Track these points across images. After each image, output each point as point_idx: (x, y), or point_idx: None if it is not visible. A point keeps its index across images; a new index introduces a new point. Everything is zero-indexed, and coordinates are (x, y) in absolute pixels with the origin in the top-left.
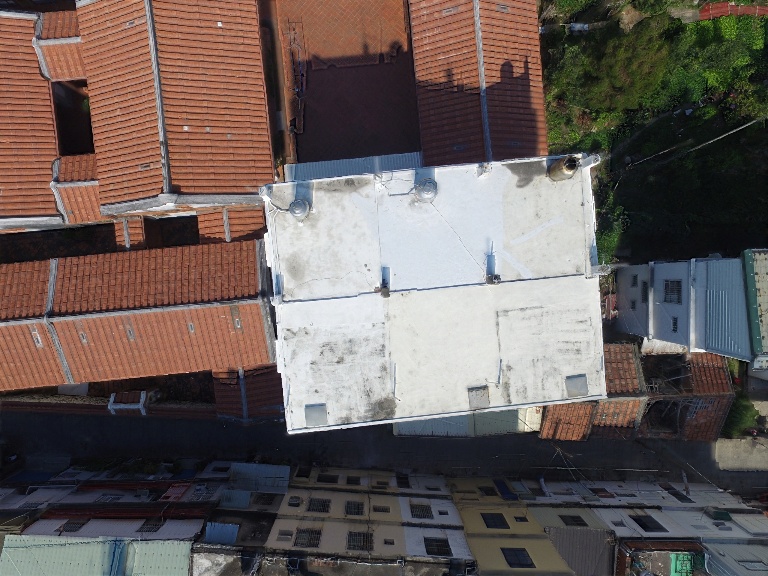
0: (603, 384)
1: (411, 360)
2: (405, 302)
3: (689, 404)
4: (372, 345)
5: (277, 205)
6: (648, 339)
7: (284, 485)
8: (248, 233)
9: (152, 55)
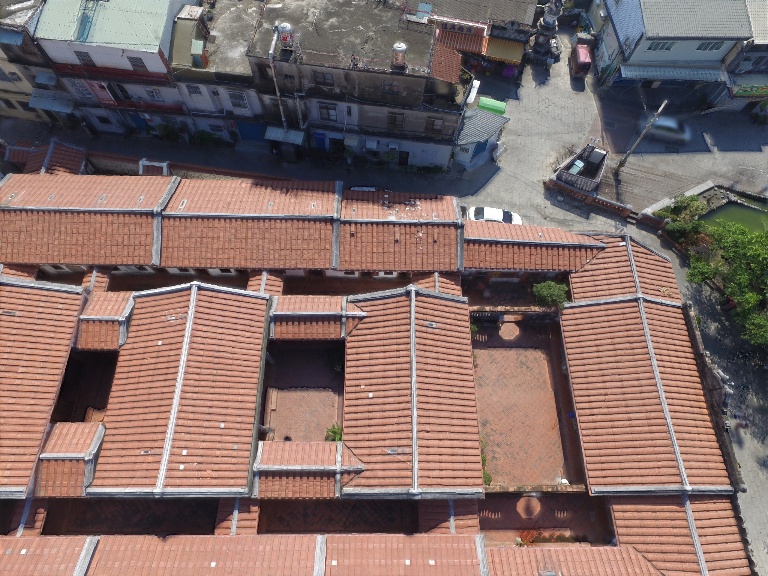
0: None
1: None
2: None
3: None
4: None
5: None
6: None
7: (35, 94)
8: None
9: None
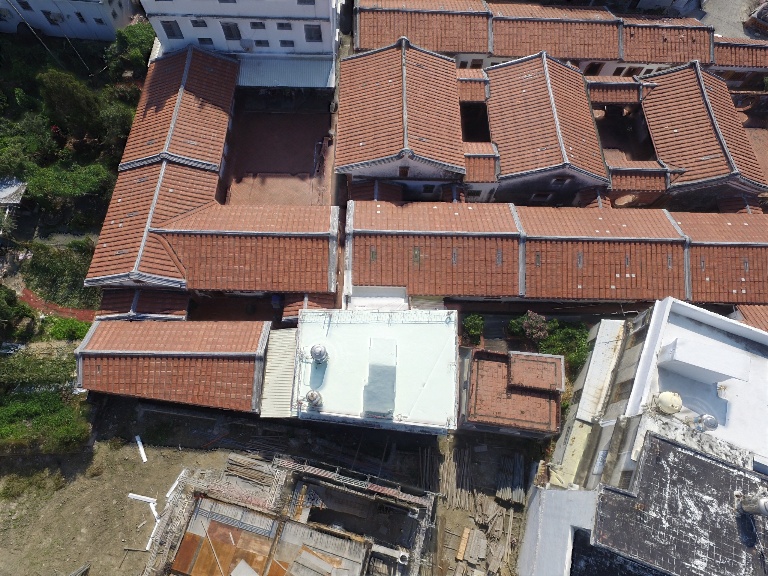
0: None
1: None
2: None
3: None
4: None
5: None
6: None
7: None
8: None
9: (405, 109)
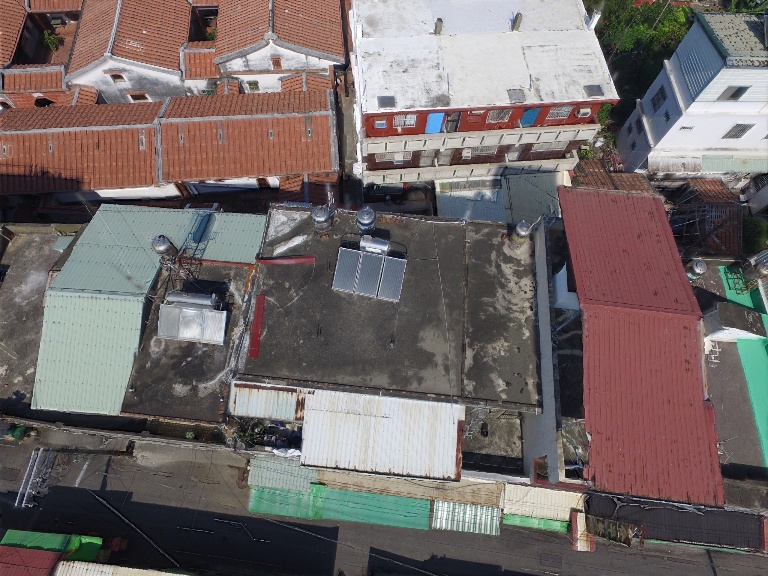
0: (614, 90)
1: (460, 72)
2: (453, 40)
3: (704, 213)
4: (429, 63)
5: None
6: (650, 148)
7: None
8: None
9: None
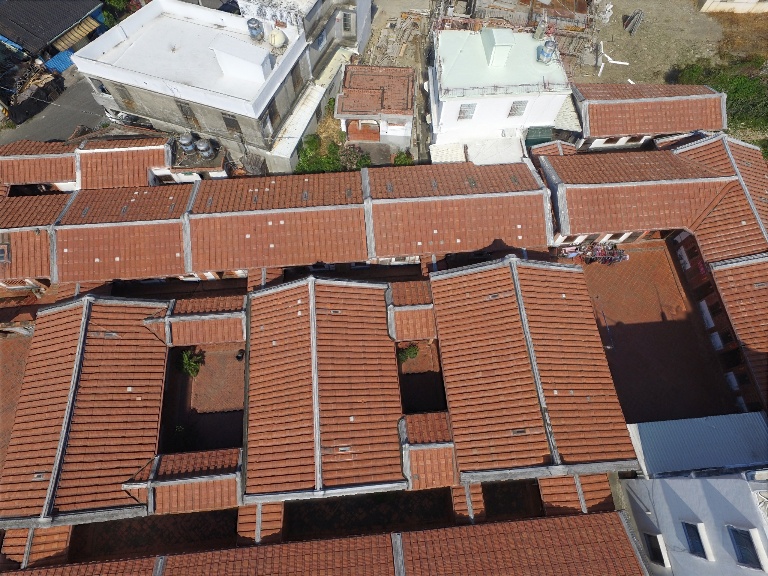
0: None
1: None
2: None
3: None
4: None
5: (766, 496)
6: None
7: None
8: (600, 501)
9: (526, 325)
